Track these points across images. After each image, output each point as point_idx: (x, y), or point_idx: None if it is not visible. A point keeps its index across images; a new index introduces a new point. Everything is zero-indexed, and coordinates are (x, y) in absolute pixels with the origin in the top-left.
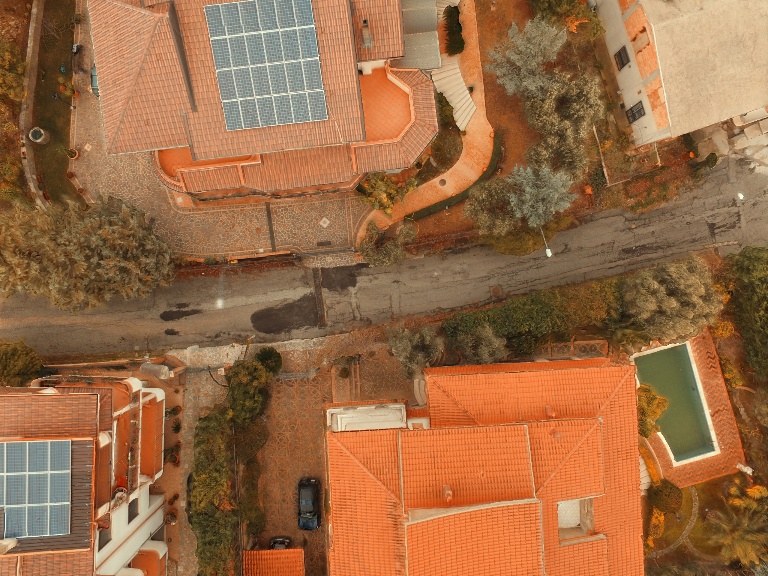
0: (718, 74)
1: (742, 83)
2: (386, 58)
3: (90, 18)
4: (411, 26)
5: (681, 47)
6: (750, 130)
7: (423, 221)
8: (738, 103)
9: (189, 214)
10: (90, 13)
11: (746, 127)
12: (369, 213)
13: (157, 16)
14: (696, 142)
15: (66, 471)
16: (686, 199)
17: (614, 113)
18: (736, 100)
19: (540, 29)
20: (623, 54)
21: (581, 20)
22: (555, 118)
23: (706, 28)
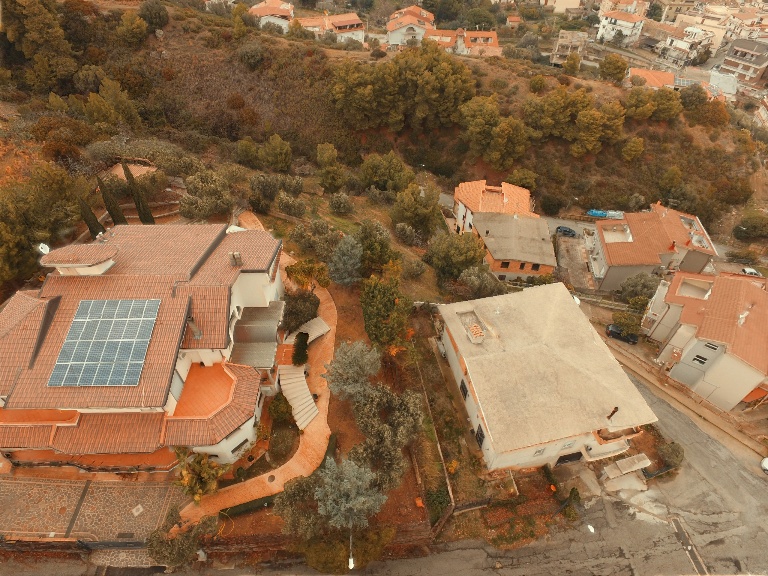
0: (530, 401)
1: (554, 410)
2: (211, 348)
3: None
4: (255, 337)
5: (491, 376)
6: (609, 469)
7: (240, 519)
8: (555, 427)
9: (1, 482)
10: None
11: None
12: (187, 504)
13: (40, 301)
14: (562, 478)
15: None
16: (561, 540)
17: (465, 437)
18: (552, 425)
19: (353, 345)
20: (463, 386)
21: (400, 348)
22: (374, 420)
23: (511, 364)
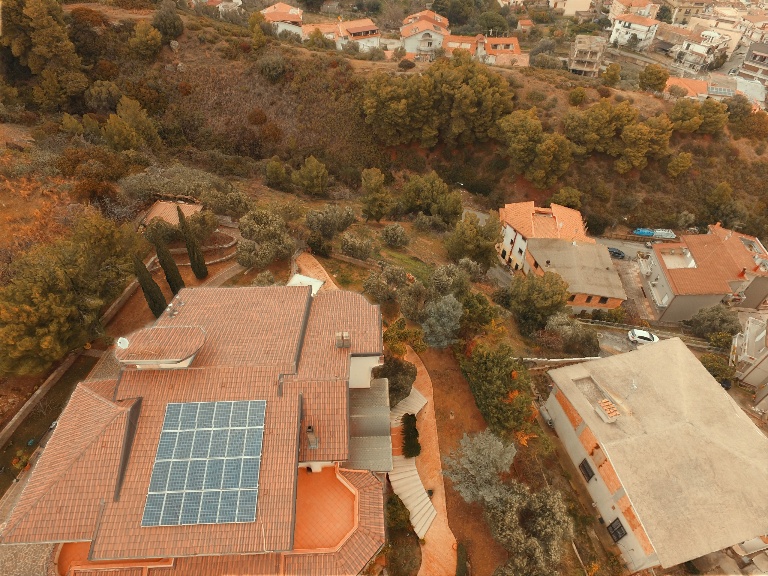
0: (687, 497)
1: (718, 508)
2: (331, 460)
3: None
4: (366, 430)
5: (638, 466)
6: (759, 561)
7: None
8: (723, 531)
9: None
10: (70, 400)
11: (754, 555)
12: None
13: (120, 409)
14: (703, 570)
15: None
16: None
17: (594, 528)
18: (720, 527)
19: (488, 442)
20: (586, 466)
21: (530, 435)
22: (520, 534)
23: (656, 450)
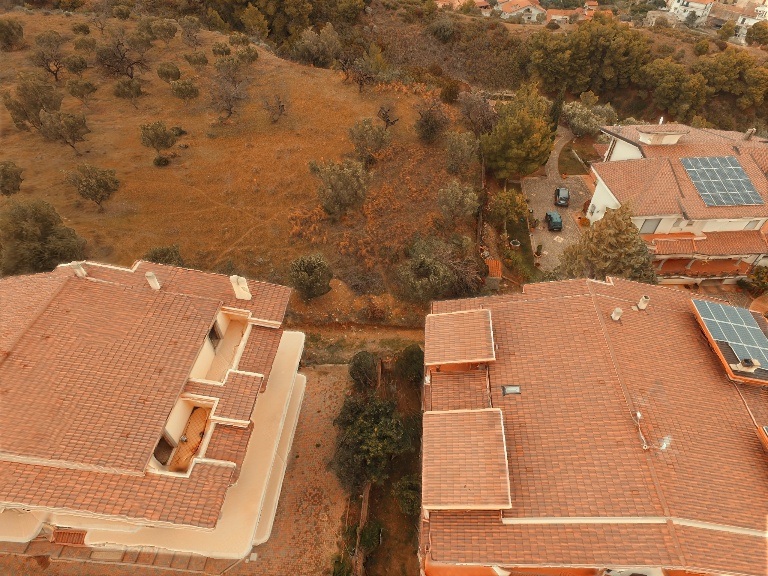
0: None
1: None
2: None
3: (597, 171)
4: None
5: None
6: None
7: None
8: None
9: None
10: (597, 170)
11: None
12: (750, 303)
13: (663, 157)
14: None
15: (757, 328)
16: None
17: None
18: None
19: None
20: None
21: None
22: None
23: None
